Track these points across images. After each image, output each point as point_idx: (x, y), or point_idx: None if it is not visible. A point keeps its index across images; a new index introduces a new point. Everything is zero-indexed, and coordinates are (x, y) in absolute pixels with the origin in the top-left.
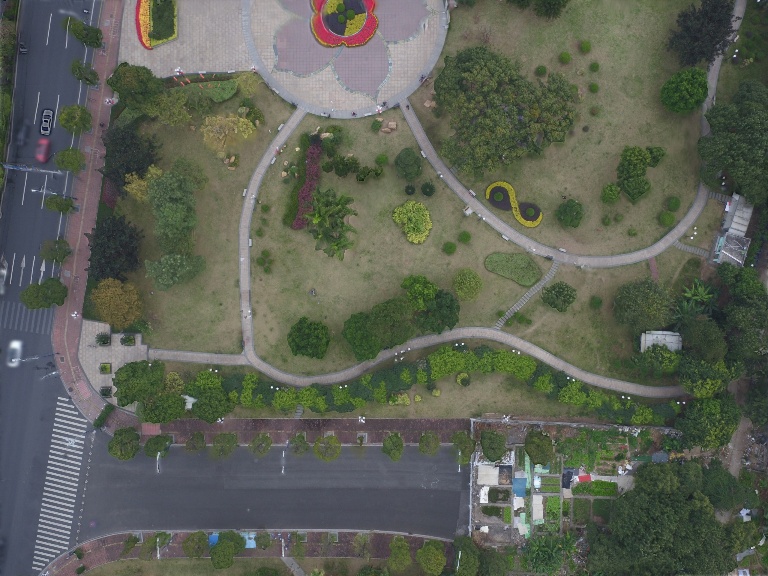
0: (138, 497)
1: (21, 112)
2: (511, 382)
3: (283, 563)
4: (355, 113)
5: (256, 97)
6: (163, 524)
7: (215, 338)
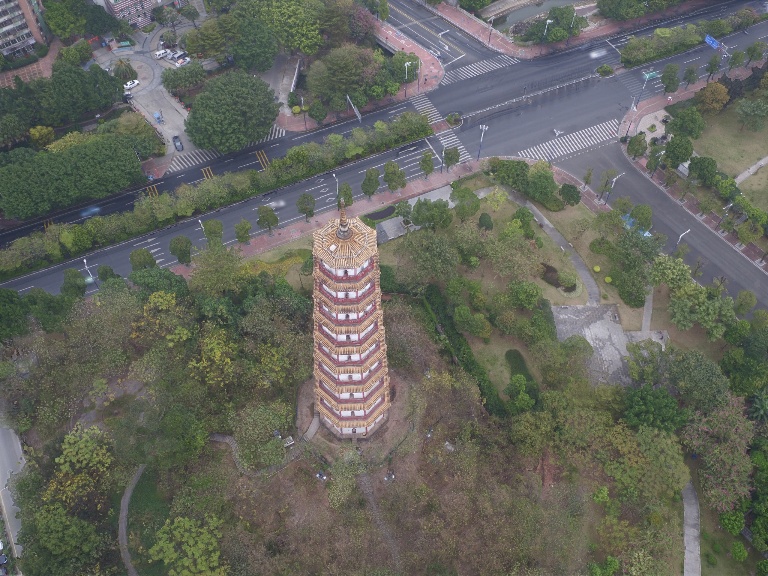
0: None
1: None
2: None
3: None
4: None
5: None
6: None
7: (723, 164)
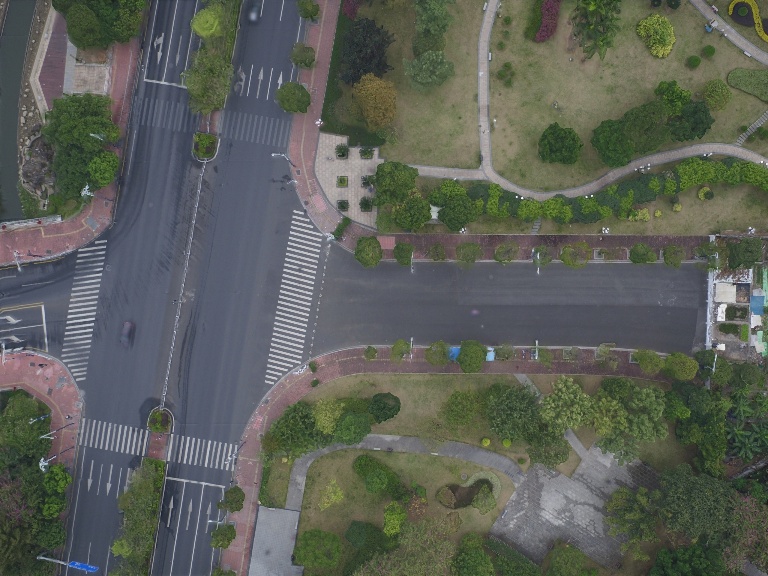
0: (372, 312)
1: None
2: (752, 198)
3: (516, 380)
4: None
5: None
6: (397, 339)
7: (453, 152)
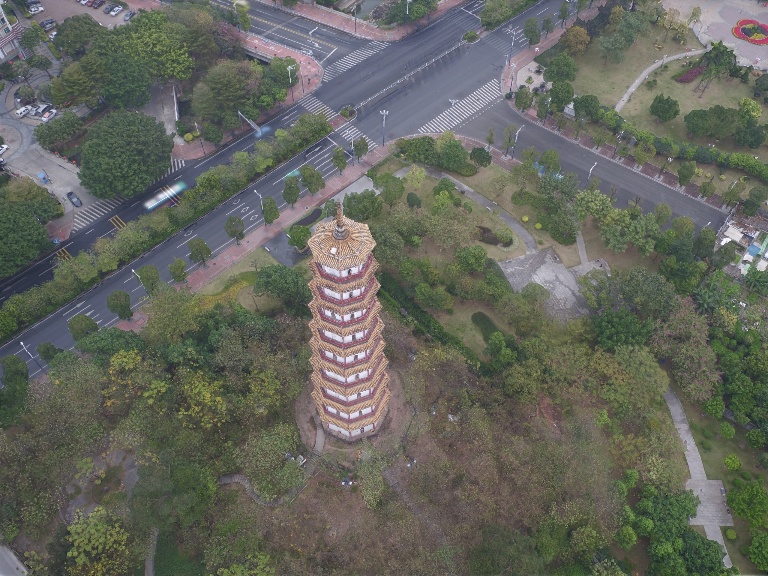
0: None
1: None
2: None
3: None
4: (739, 62)
5: (687, 36)
6: None
7: (600, 98)
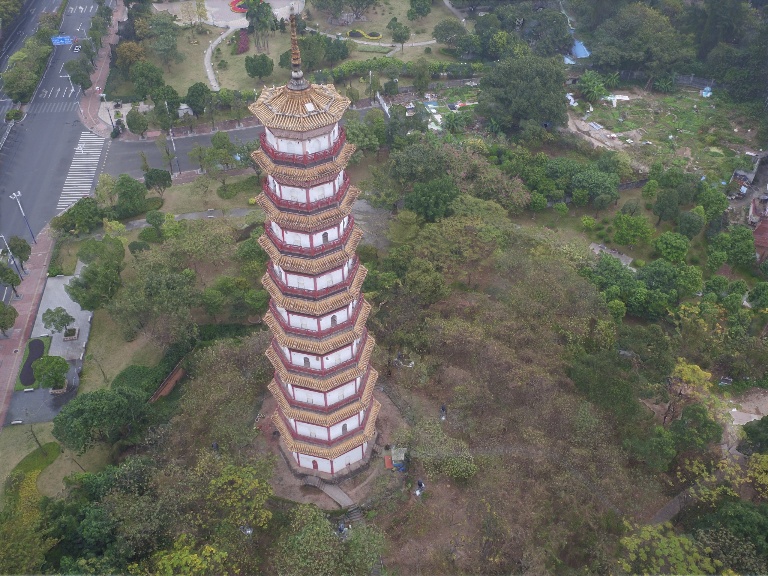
0: None
1: (61, 48)
2: None
3: None
4: None
5: (206, 27)
6: None
7: None
